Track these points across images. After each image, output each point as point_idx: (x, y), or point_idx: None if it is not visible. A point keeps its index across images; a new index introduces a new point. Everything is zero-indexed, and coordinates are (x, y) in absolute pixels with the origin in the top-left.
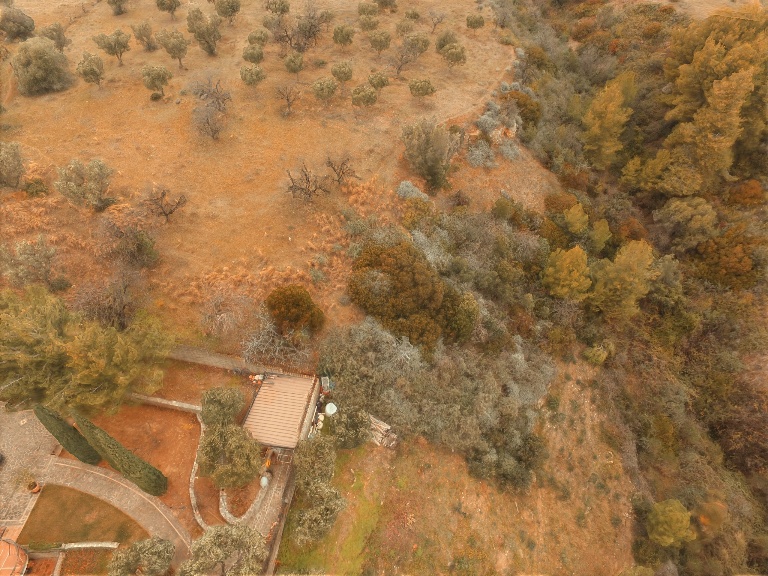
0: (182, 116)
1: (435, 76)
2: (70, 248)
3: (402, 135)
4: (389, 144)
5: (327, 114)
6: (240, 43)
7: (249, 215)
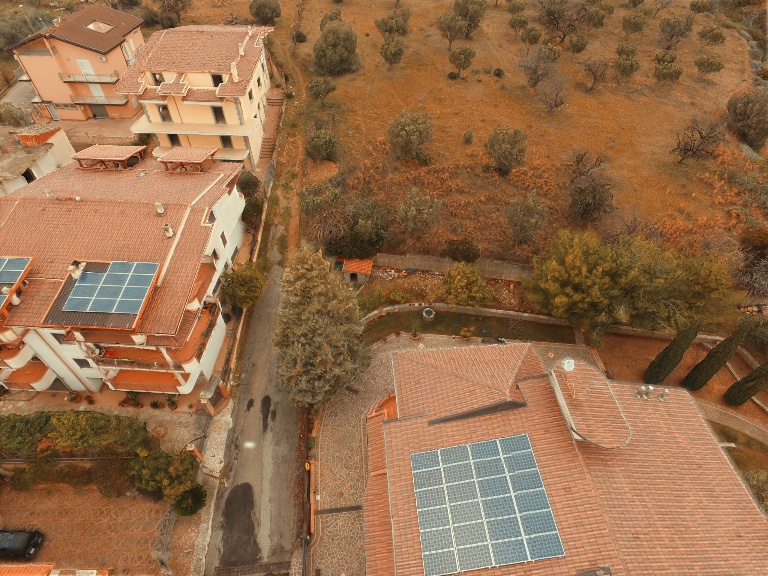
0: (494, 92)
1: (691, 55)
2: (502, 207)
3: (743, 104)
4: (703, 114)
5: (625, 89)
6: (485, 27)
7: (637, 176)
